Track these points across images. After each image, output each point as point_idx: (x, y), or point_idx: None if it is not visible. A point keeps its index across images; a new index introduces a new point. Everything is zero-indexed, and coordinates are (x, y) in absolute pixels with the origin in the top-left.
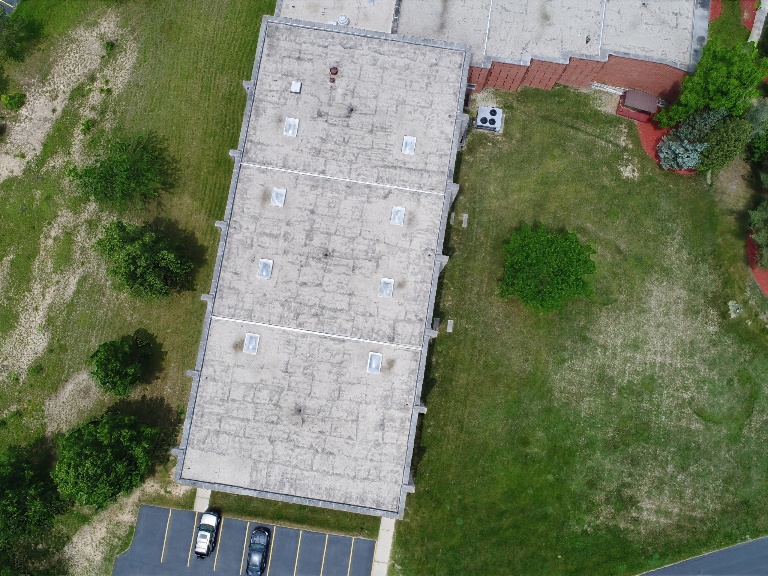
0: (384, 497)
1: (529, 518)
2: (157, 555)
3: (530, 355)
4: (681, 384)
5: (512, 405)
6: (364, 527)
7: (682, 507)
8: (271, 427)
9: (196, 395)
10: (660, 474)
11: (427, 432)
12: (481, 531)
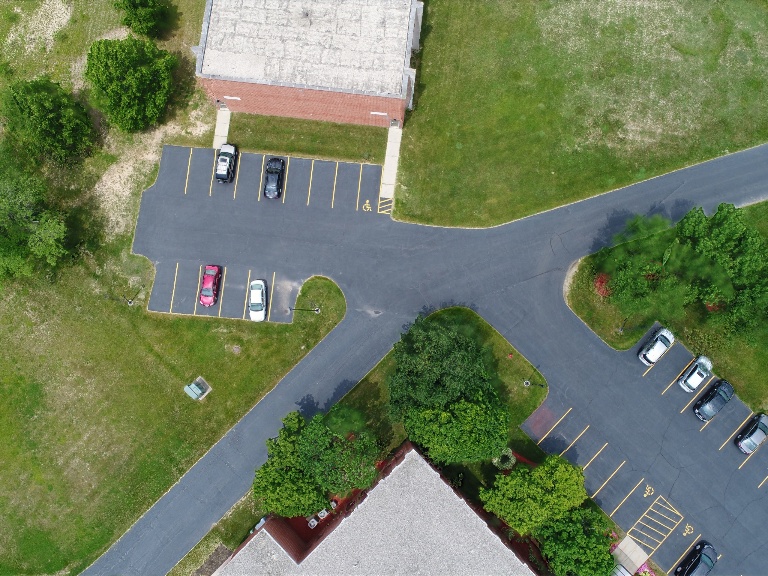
0: (388, 83)
1: (523, 141)
2: (181, 188)
3: (518, 2)
4: (659, 23)
5: (503, 45)
6: (371, 154)
7: (665, 128)
8: (282, 29)
9: (212, 3)
10: (643, 100)
11: (426, 71)
12: (479, 153)
